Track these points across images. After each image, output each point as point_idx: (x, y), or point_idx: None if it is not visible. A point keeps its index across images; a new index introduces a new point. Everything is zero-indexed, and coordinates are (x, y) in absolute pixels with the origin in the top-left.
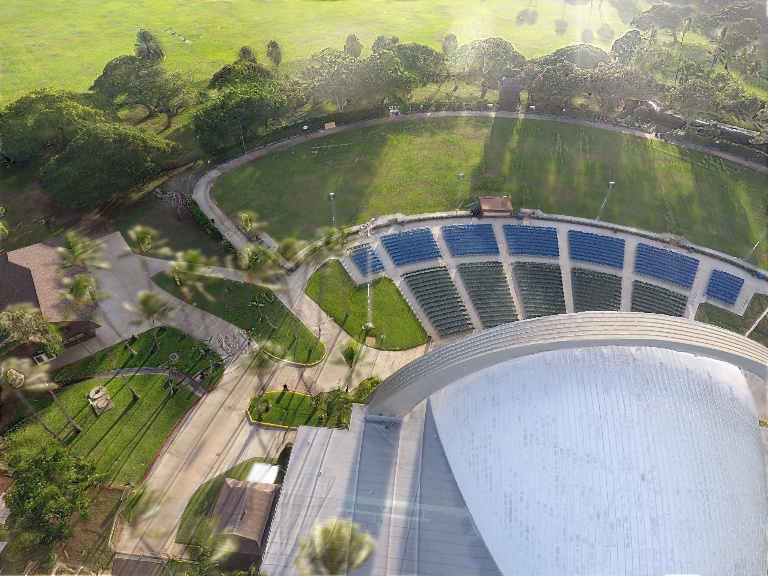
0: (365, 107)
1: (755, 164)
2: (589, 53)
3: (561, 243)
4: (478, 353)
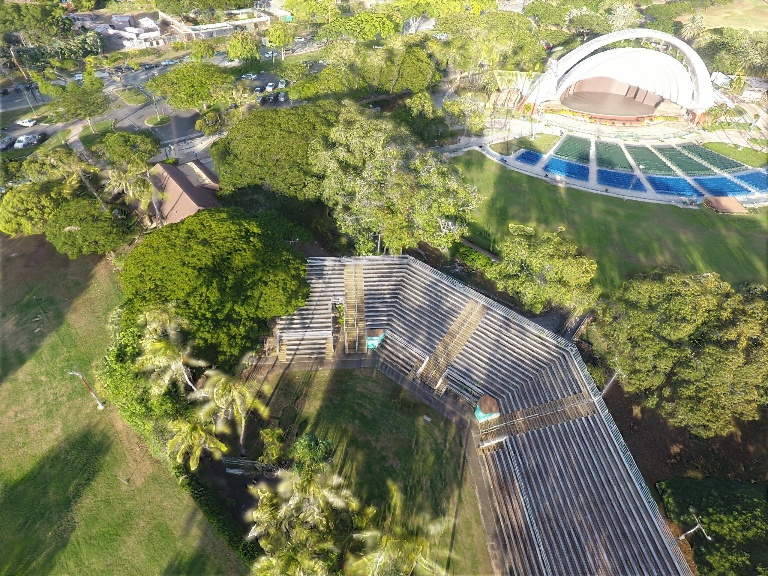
0: None
1: None
2: None
3: (648, 186)
4: None
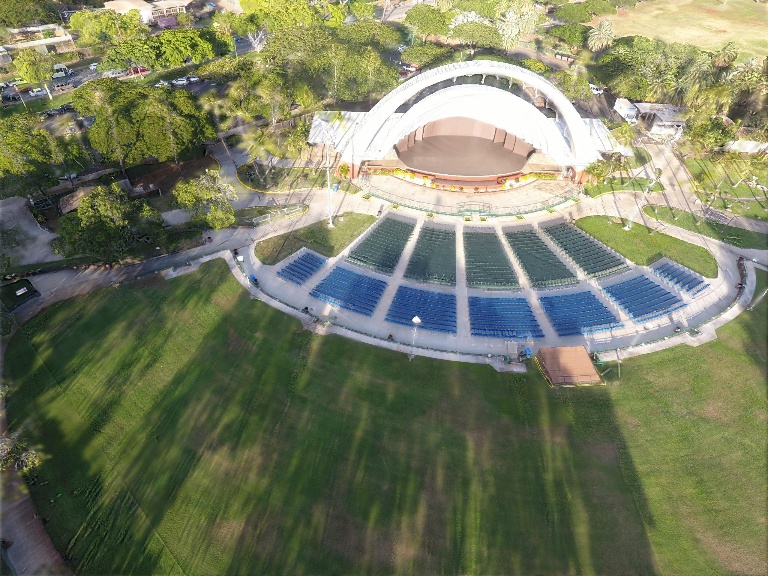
0: None
1: (5, 526)
2: None
3: (465, 318)
4: None
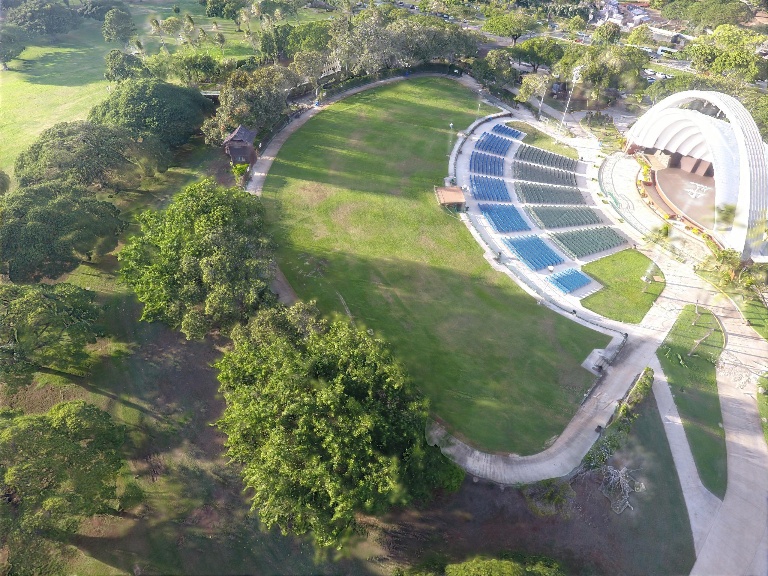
0: (144, 305)
1: (365, 86)
2: (162, 84)
3: None
4: (764, 158)
